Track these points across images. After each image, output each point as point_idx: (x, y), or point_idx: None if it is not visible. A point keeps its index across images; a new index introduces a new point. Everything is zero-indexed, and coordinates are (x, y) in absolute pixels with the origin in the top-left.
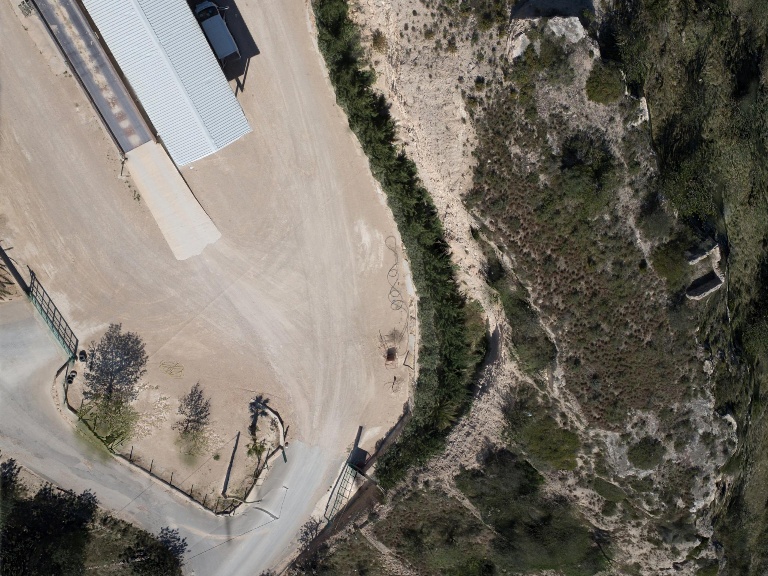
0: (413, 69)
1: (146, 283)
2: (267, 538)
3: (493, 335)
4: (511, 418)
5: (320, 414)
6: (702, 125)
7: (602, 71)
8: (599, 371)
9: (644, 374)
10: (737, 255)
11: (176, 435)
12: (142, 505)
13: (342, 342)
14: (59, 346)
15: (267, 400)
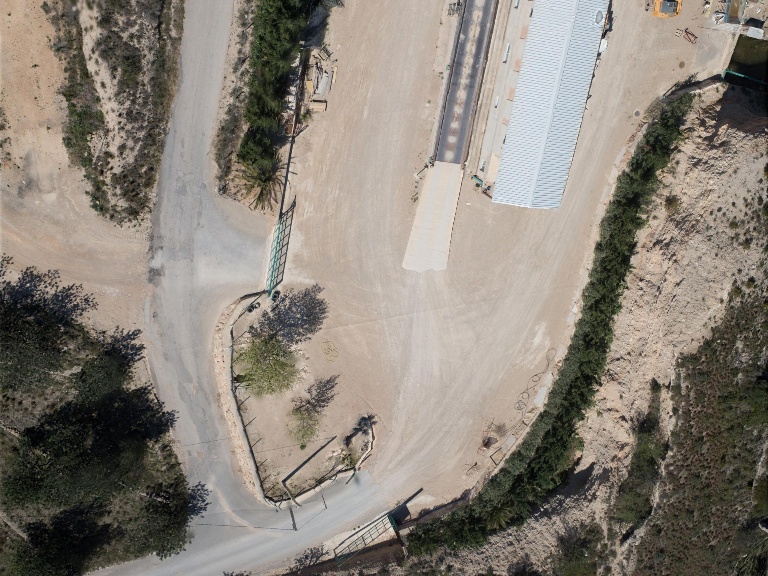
0: (705, 242)
1: (367, 269)
2: (273, 543)
3: (581, 473)
4: (565, 549)
5: (401, 459)
6: None
7: None
8: (667, 548)
9: (692, 569)
10: None
11: (290, 408)
12: (203, 452)
13: (462, 410)
14: (265, 275)
15: (375, 422)
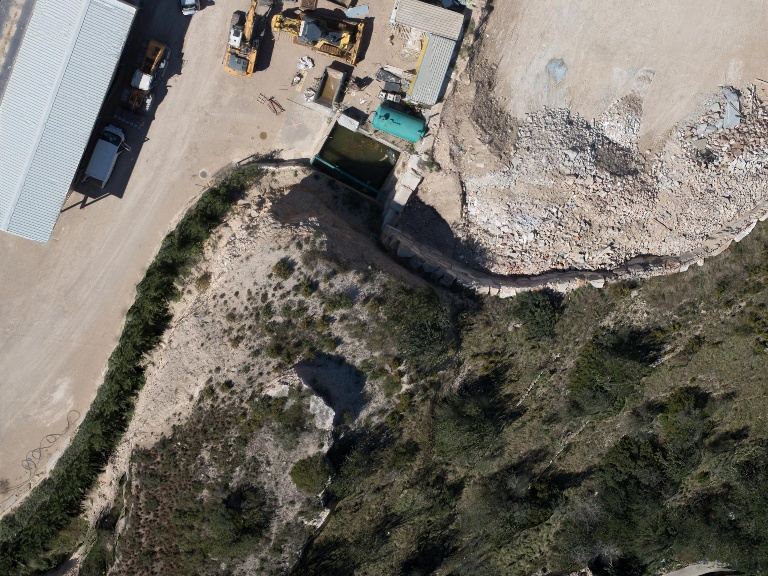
0: (197, 327)
1: None
2: None
3: (71, 561)
4: None
5: None
6: (362, 564)
7: (316, 465)
8: None
9: None
10: None
11: None
12: None
13: None
14: None
15: None
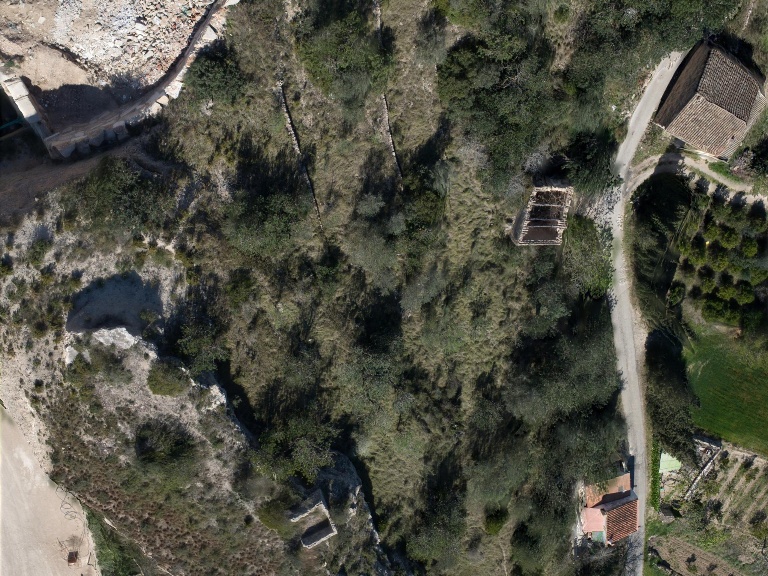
0: None
1: None
2: None
3: None
4: None
5: None
6: (321, 377)
7: (158, 372)
8: None
9: None
10: (392, 475)
11: None
12: None
13: (22, 548)
14: None
15: None
